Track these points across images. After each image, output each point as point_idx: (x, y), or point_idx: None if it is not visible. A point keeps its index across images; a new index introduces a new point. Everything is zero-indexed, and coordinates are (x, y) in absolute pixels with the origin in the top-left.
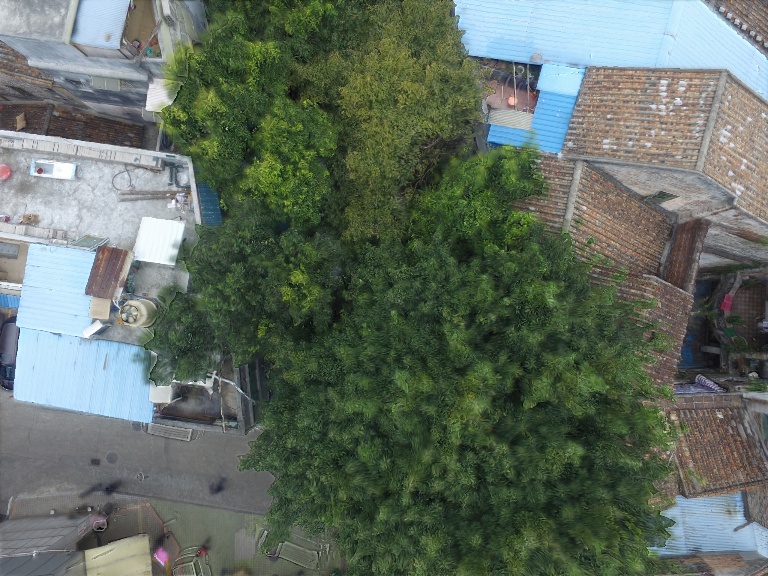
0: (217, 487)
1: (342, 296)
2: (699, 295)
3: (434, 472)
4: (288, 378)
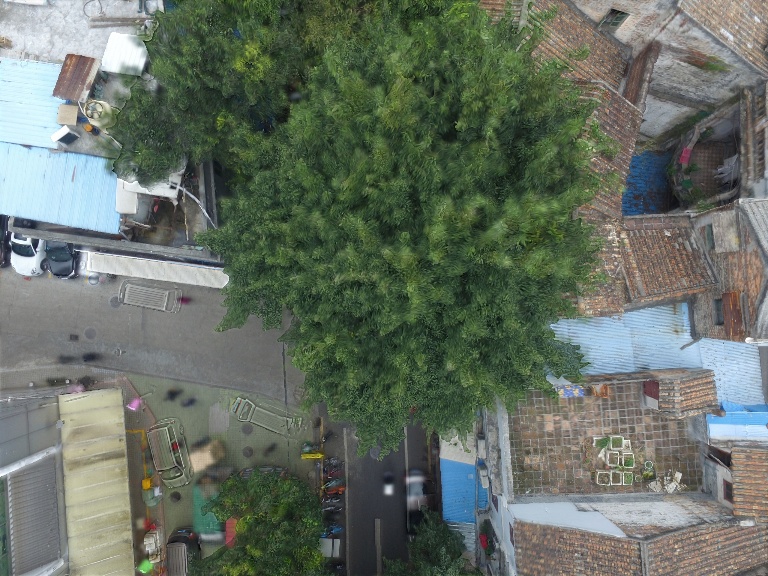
0: (193, 362)
1: (298, 88)
2: (663, 166)
3: (368, 180)
4: (243, 155)
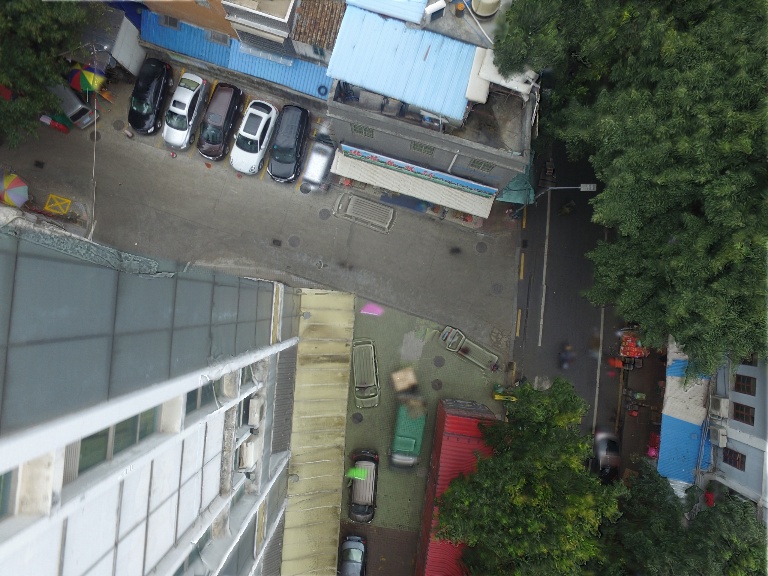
0: (393, 287)
1: None
2: None
3: None
4: (669, 49)
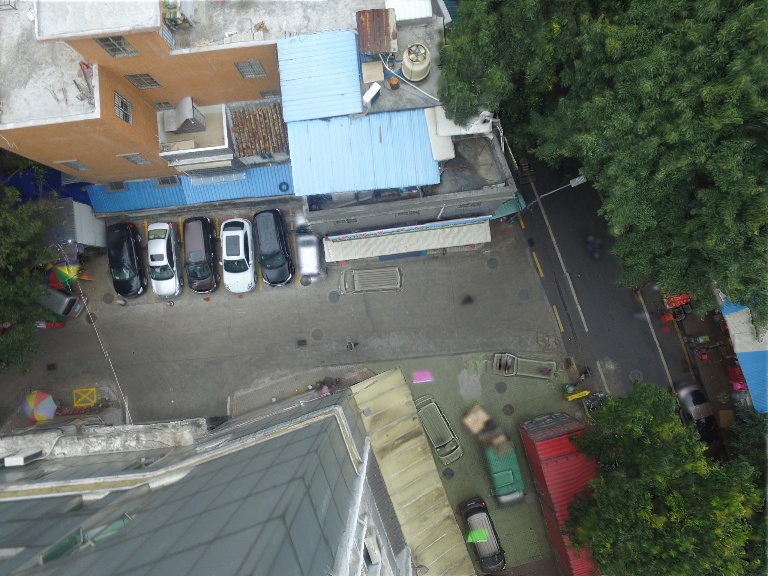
0: (427, 336)
1: None
2: None
3: None
4: (613, 46)
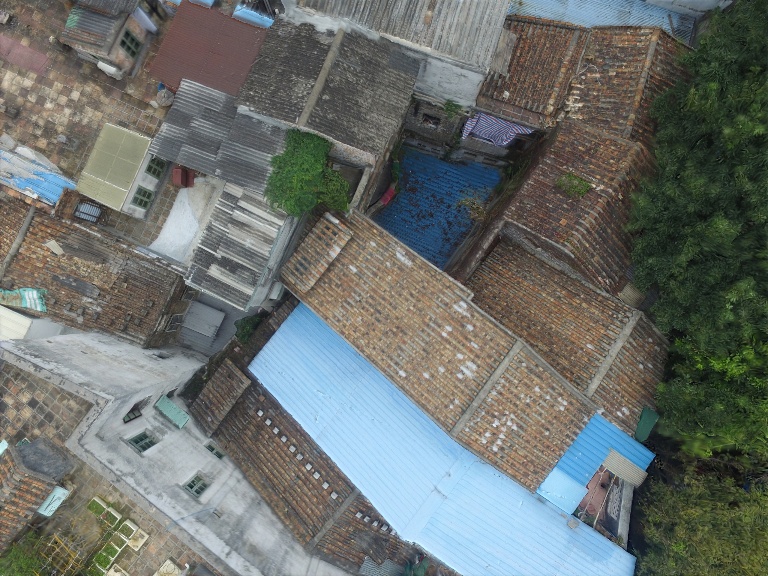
0: None
1: None
2: None
3: None
4: None
